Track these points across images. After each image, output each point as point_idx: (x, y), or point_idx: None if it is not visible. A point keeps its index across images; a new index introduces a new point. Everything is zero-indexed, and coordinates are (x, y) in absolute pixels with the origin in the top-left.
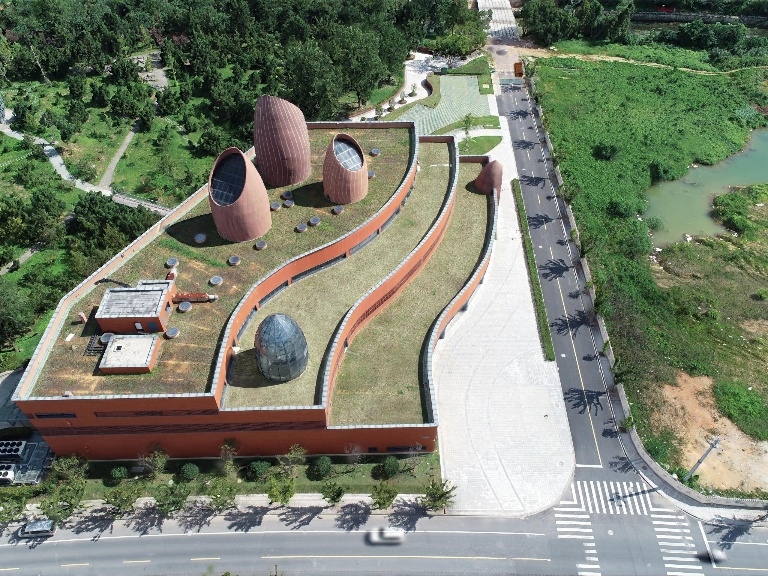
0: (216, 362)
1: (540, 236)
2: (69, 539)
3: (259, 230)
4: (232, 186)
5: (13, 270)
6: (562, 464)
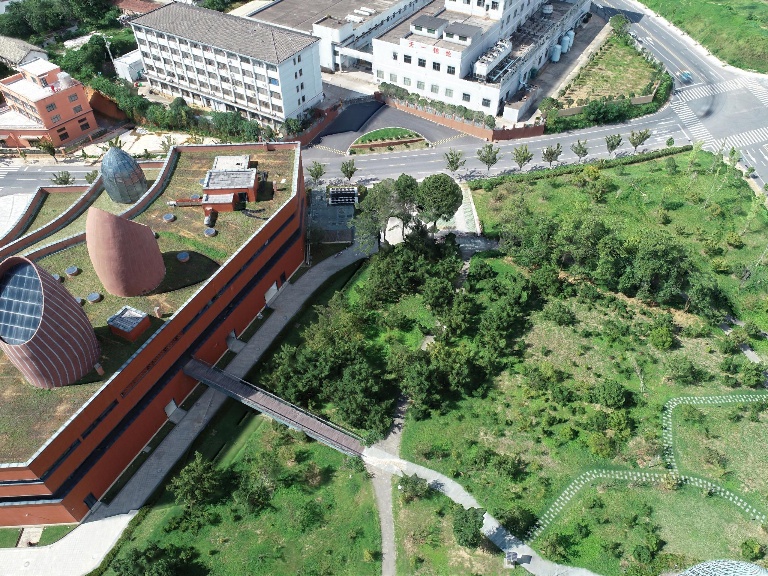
0: (172, 169)
1: None
2: None
3: None
4: None
5: (428, 332)
6: None
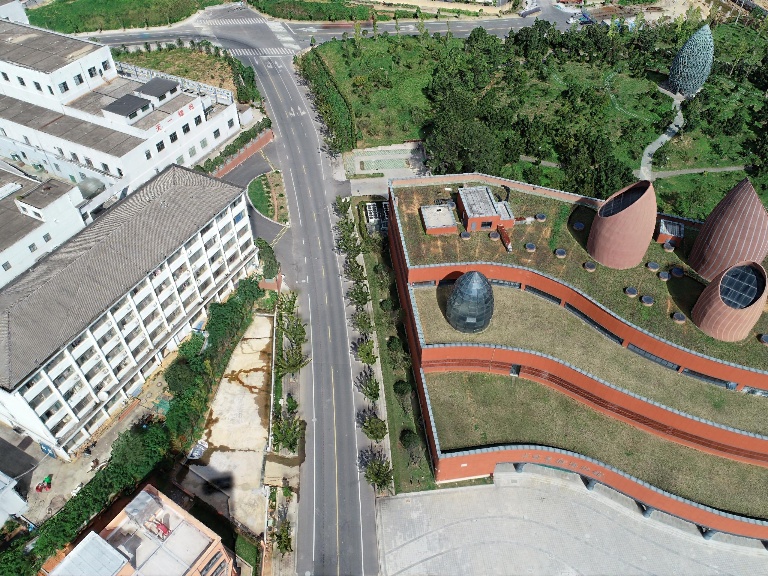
0: None
1: None
2: (339, 264)
3: (605, 258)
4: (619, 208)
5: (535, 164)
6: None
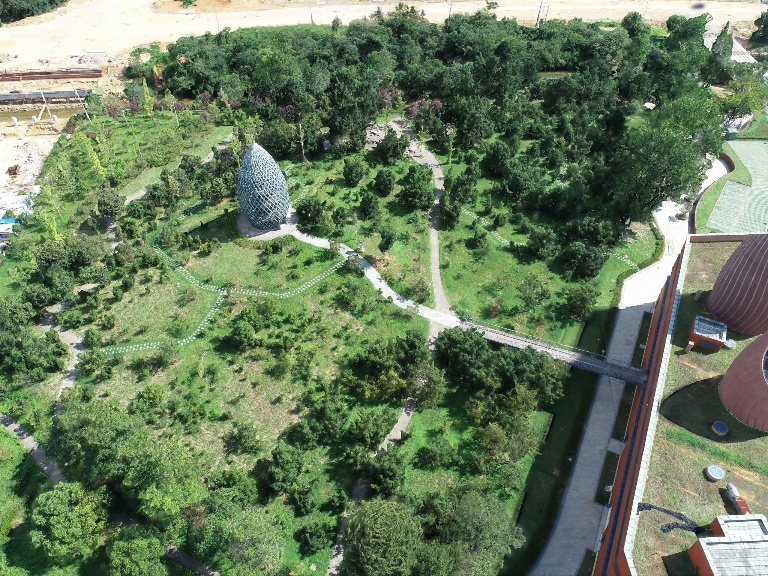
0: None
1: None
2: None
3: None
4: None
5: (399, 443)
6: None
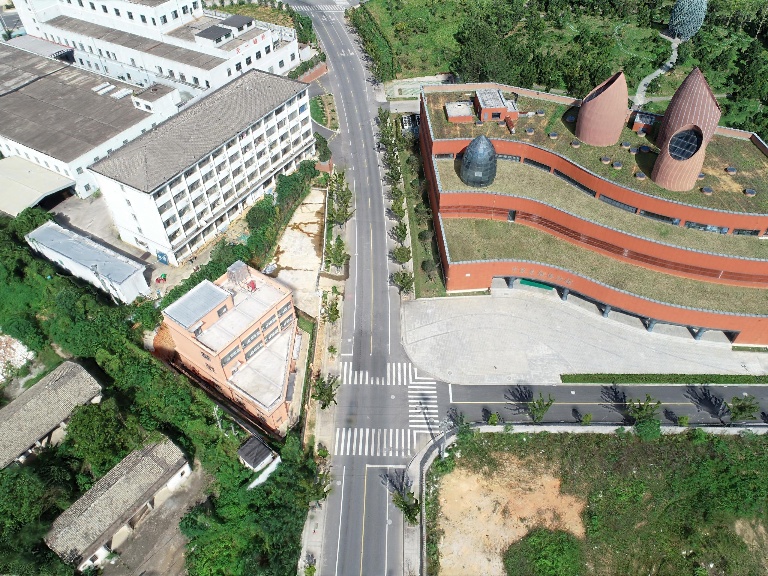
0: None
1: (767, 396)
2: (379, 158)
3: (587, 137)
4: None
5: None
6: (449, 373)
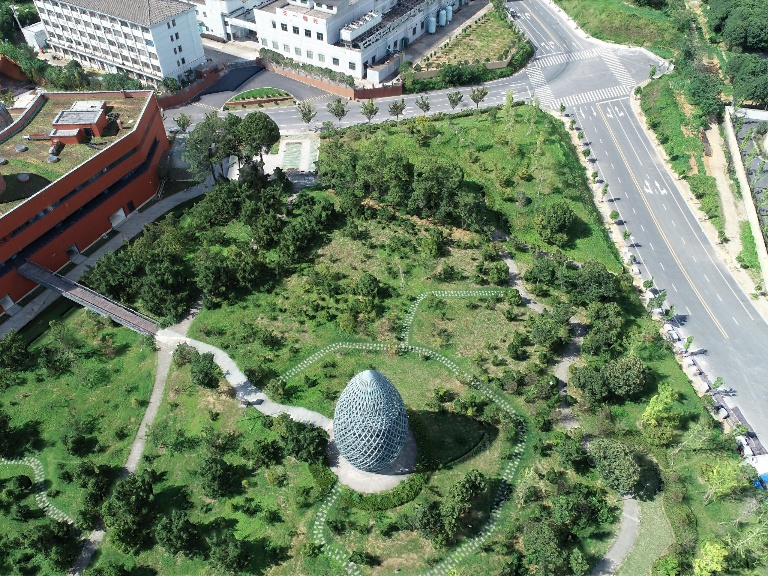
0: (37, 112)
1: None
2: None
3: None
4: None
5: None
6: None
